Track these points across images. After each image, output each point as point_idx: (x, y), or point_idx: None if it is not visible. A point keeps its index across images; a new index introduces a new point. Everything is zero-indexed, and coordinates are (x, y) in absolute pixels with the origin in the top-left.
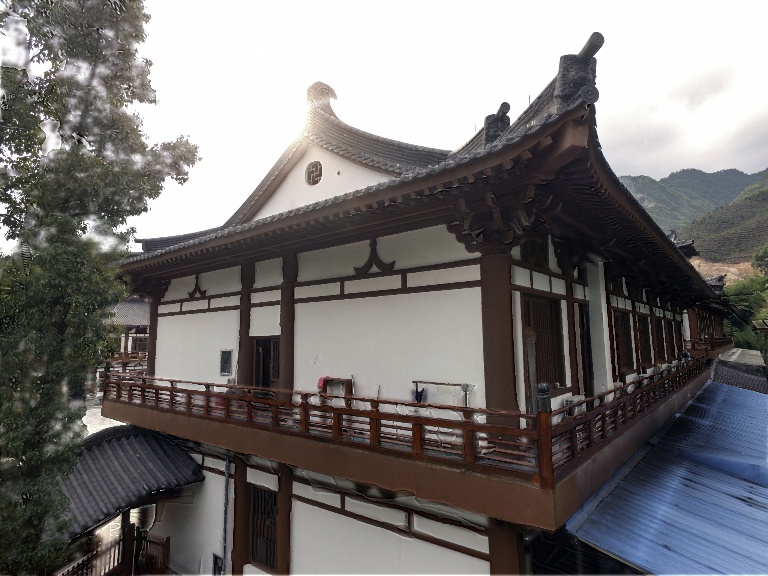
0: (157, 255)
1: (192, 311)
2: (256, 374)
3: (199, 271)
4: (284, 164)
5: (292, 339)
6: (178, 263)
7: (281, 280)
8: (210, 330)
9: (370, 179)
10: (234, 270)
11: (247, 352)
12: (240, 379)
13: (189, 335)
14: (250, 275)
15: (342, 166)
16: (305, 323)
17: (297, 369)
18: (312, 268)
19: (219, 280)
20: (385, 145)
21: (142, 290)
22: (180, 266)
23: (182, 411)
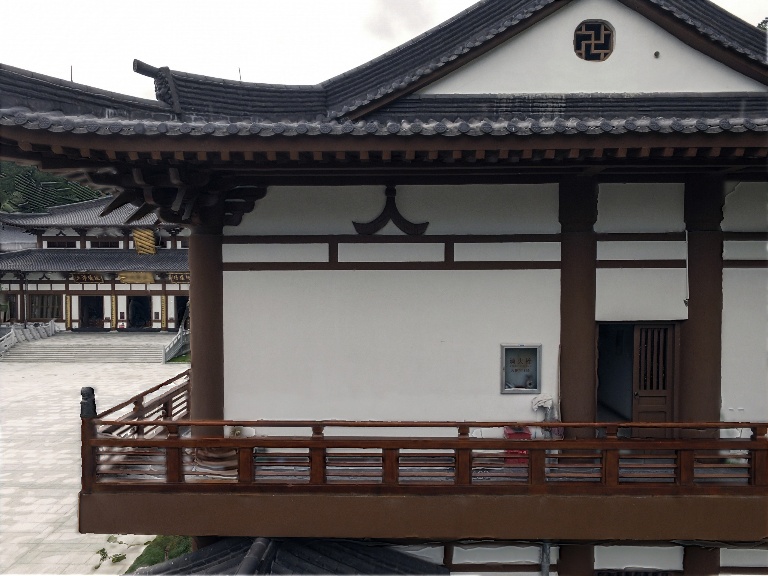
0: (518, 134)
1: (382, 264)
2: (597, 386)
3: (412, 180)
4: (546, 4)
5: (718, 327)
6: (499, 161)
7: (679, 224)
8: (457, 306)
9: (723, 80)
10: (530, 191)
11: (593, 349)
12: (585, 399)
13: (374, 315)
14: (592, 206)
15: (665, 45)
16: (750, 301)
17: (730, 375)
18: (762, 211)
19: (477, 206)
20: (761, 35)
21: (193, 203)
22: (431, 165)
23: (520, 486)
